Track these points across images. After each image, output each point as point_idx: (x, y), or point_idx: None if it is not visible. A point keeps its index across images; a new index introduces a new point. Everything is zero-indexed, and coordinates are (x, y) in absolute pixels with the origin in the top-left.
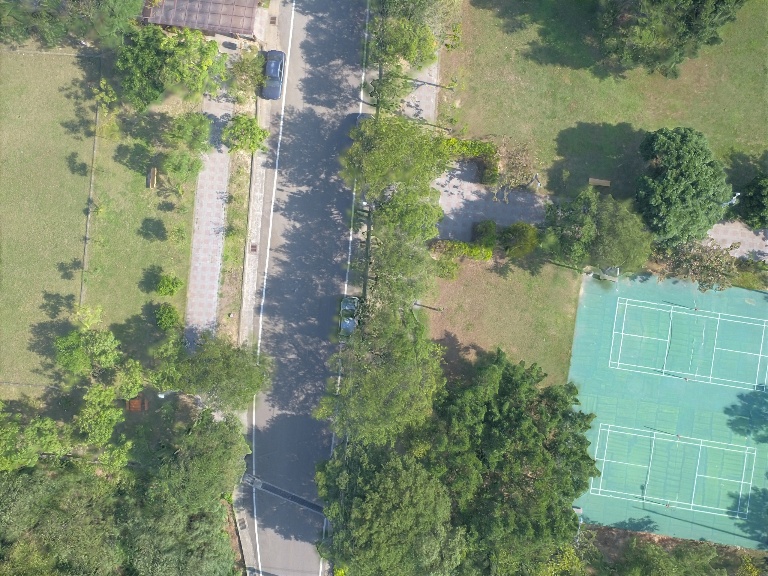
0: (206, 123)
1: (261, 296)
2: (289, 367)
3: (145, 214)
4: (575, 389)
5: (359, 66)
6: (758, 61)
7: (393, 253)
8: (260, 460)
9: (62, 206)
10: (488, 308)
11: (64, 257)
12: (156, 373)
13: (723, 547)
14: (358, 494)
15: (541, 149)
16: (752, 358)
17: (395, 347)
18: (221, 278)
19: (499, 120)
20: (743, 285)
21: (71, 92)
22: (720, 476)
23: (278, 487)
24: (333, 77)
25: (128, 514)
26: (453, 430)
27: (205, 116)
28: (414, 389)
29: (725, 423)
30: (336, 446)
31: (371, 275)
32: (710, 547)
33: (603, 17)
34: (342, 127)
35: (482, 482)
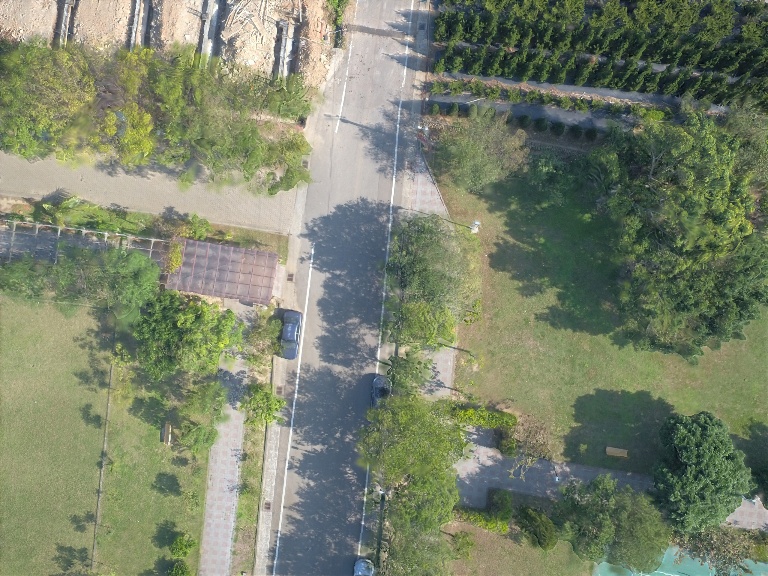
0: (221, 379)
1: (274, 554)
2: None
3: (159, 469)
4: None
5: (376, 325)
6: None
7: (409, 543)
8: None
9: (76, 458)
10: (502, 574)
11: (77, 509)
12: None
13: None
14: None
15: (558, 415)
16: None
17: None
18: (234, 535)
19: (517, 385)
20: (759, 558)
21: (86, 343)
22: None
23: None
24: (350, 336)
25: None
26: None
27: (220, 372)
28: None
29: None
30: None
31: (385, 536)
32: None
33: (625, 300)
34: (358, 386)
35: None
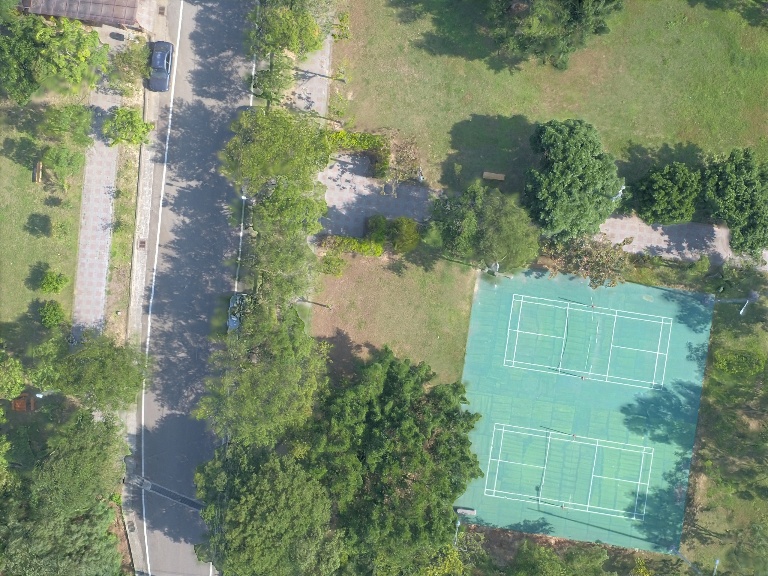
0: (93, 116)
1: (150, 293)
2: (178, 366)
3: (31, 209)
4: (462, 388)
5: (250, 57)
6: (657, 52)
7: (273, 249)
8: (149, 461)
9: None
10: (381, 305)
11: None
12: (36, 372)
13: (621, 549)
14: (235, 496)
15: (435, 142)
16: (649, 356)
17: (270, 345)
18: (109, 275)
19: (392, 112)
20: (641, 281)
21: None
22: (616, 477)
23: (167, 489)
24: (223, 69)
25: (10, 517)
26: (333, 430)
27: (92, 109)
28: (290, 388)
29: (622, 422)
30: (218, 447)
31: None
32: (601, 549)
33: (492, 6)
34: (232, 120)
35: (362, 483)
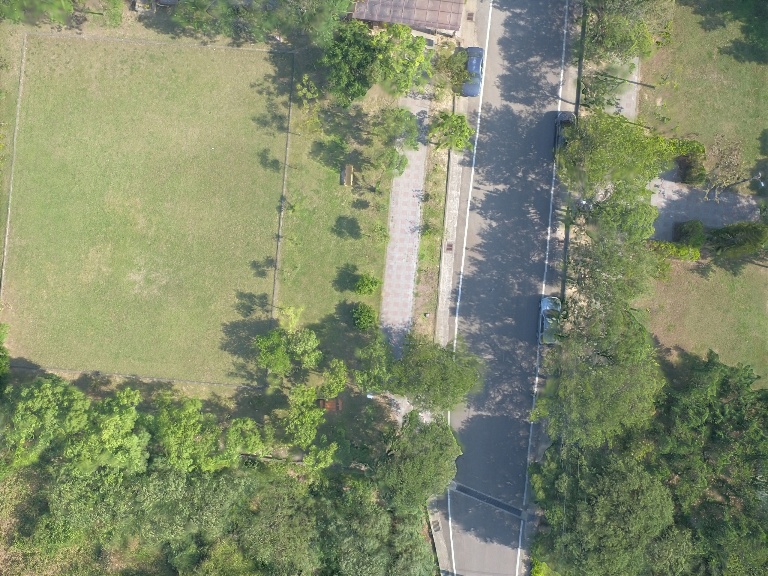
0: (402, 120)
1: (457, 296)
2: (485, 368)
3: (339, 212)
4: None
5: (558, 63)
6: None
7: (612, 253)
8: (455, 461)
9: (254, 203)
10: (690, 309)
11: (256, 255)
12: (361, 373)
13: None
14: (580, 497)
15: (744, 148)
16: None
17: (623, 348)
18: (417, 277)
19: (701, 119)
20: None
21: (263, 88)
22: None
23: (473, 489)
24: (531, 74)
25: (328, 515)
26: (675, 432)
27: (401, 113)
28: (641, 391)
29: None
30: (548, 448)
31: (569, 275)
32: None
33: None
34: (540, 125)
35: (706, 485)
